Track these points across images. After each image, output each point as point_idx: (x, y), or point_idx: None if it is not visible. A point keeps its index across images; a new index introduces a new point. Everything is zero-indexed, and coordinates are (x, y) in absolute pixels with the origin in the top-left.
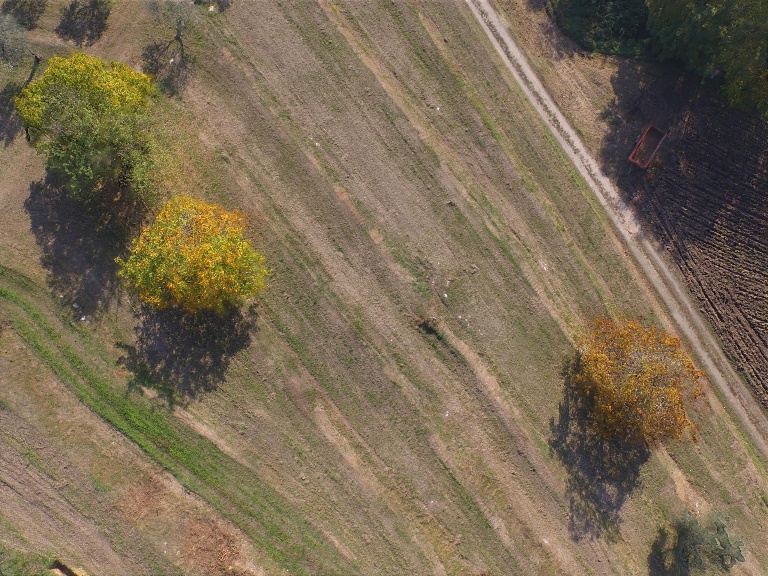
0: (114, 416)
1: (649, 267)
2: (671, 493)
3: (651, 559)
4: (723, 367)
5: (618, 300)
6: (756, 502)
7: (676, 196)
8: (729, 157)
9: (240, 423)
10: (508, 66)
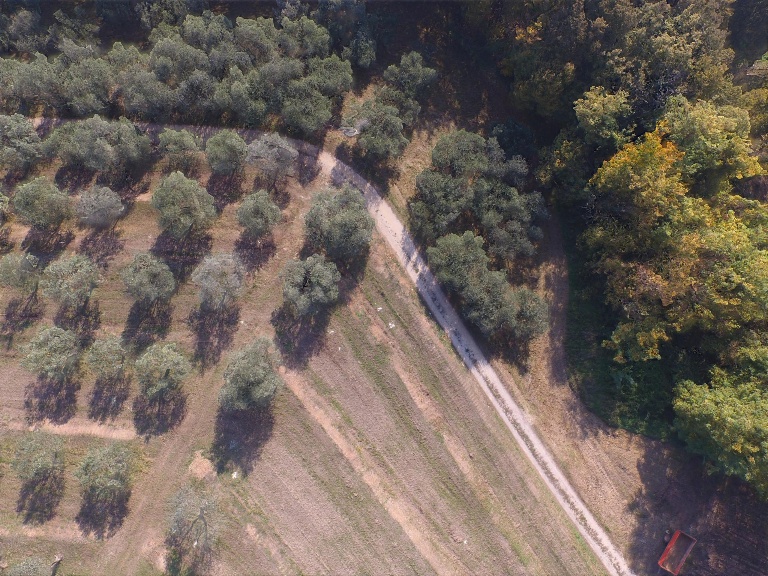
0: None
1: None
2: None
3: None
4: None
5: None
6: None
7: None
8: (759, 549)
9: None
10: (533, 464)
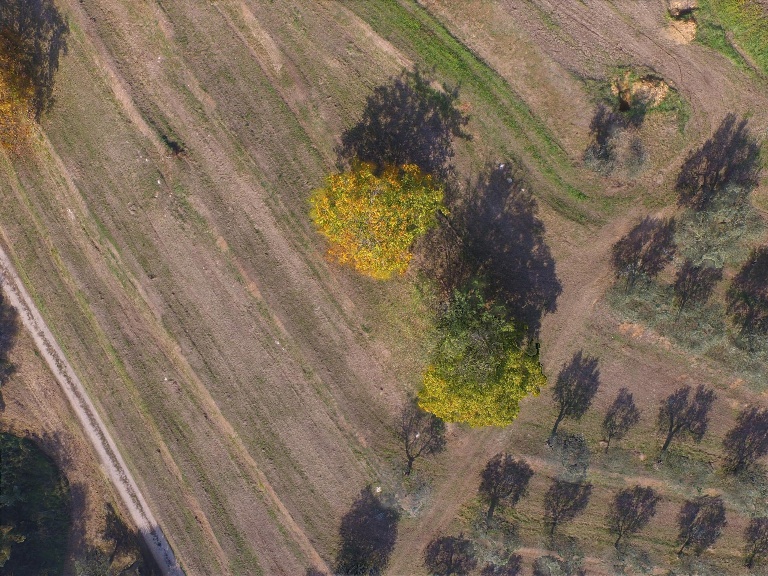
0: (474, 65)
1: None
2: None
3: None
4: None
5: (5, 179)
6: None
7: None
8: None
9: (353, 54)
10: (103, 425)
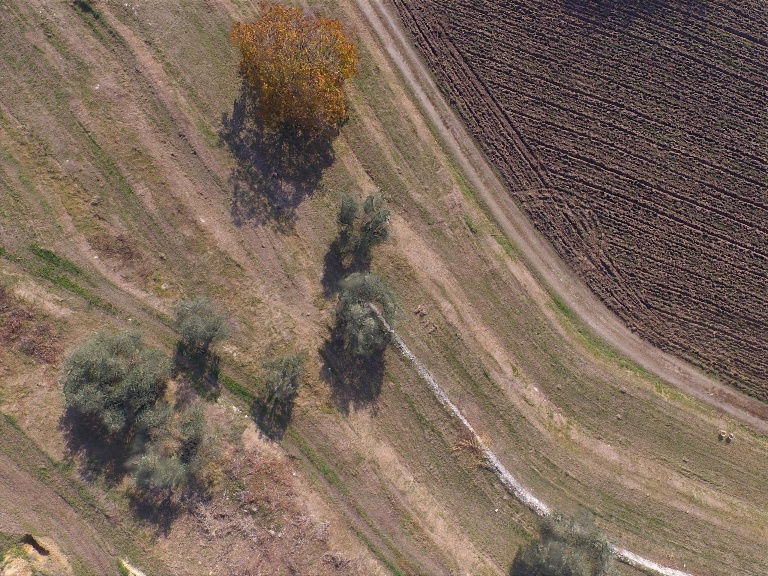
0: None
1: (364, 2)
2: (356, 199)
3: (328, 257)
4: (436, 101)
5: None
6: (459, 226)
7: None
8: None
9: None
10: None
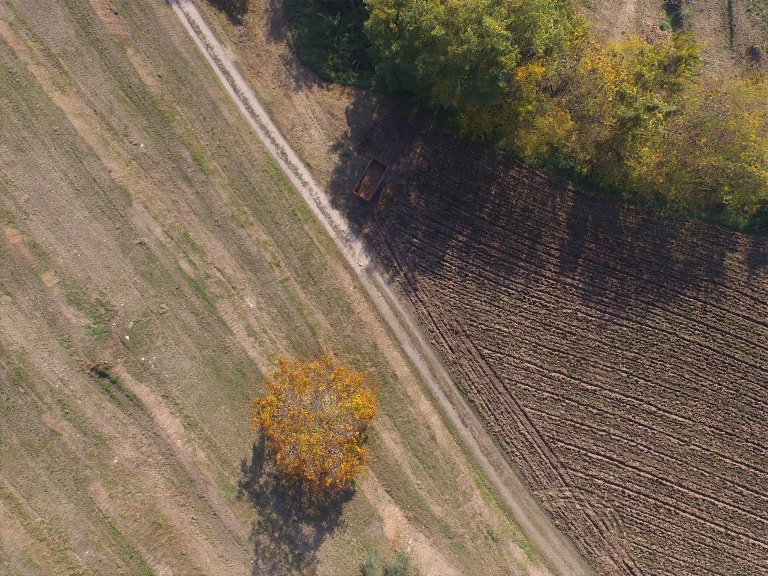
0: None
1: (379, 299)
2: (377, 531)
3: None
4: (454, 399)
5: (338, 334)
6: (480, 536)
7: (407, 228)
8: (461, 188)
9: None
10: (234, 99)
